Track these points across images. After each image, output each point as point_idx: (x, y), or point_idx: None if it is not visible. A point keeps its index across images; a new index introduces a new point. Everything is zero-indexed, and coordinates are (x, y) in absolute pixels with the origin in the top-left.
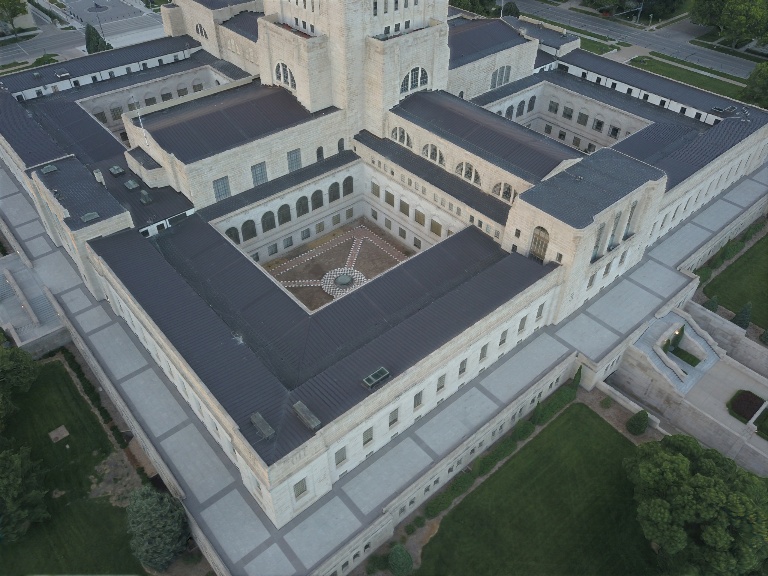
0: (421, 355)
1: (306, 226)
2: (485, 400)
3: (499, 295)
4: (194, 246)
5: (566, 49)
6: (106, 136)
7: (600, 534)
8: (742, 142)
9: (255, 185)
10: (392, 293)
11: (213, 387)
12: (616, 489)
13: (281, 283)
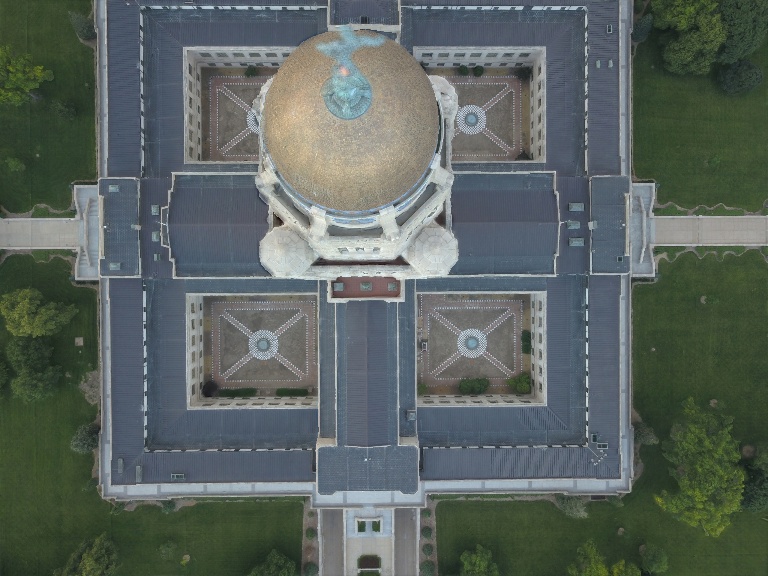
0: (206, 479)
1: None
2: None
3: (271, 474)
4: (169, 307)
5: None
6: (180, 130)
7: (249, 552)
8: (549, 480)
9: None
10: (236, 422)
11: (115, 430)
12: (274, 544)
13: (231, 318)
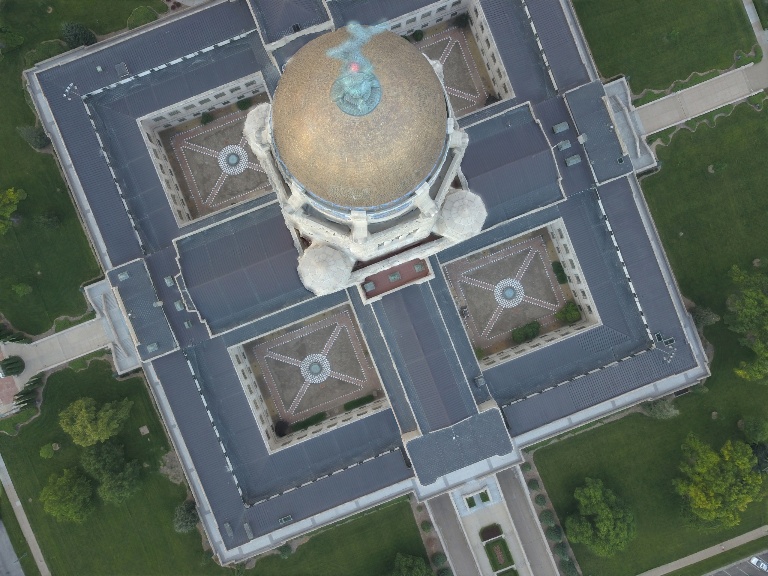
0: (312, 512)
1: None
2: (352, 502)
3: (370, 485)
4: (216, 367)
5: None
6: (163, 198)
7: (376, 565)
8: None
9: None
10: (319, 449)
11: (211, 498)
12: (396, 549)
13: (276, 355)
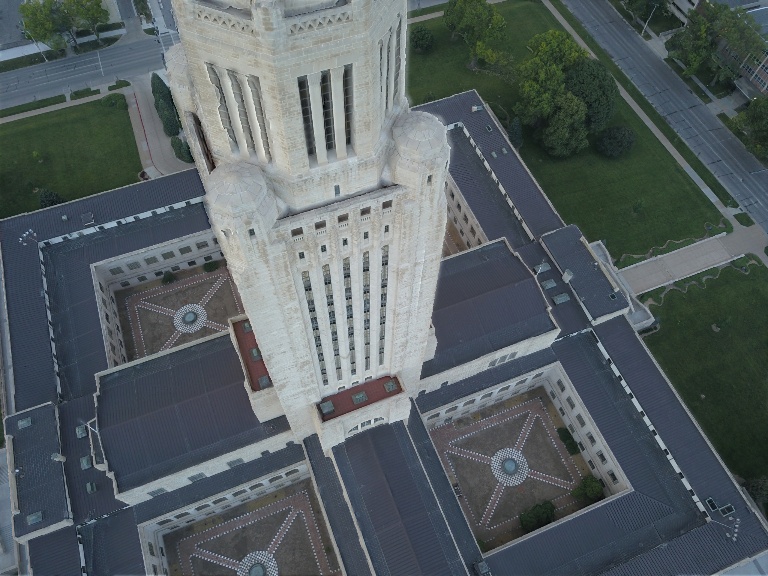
0: None
1: None
2: None
3: None
4: (118, 554)
5: (605, 319)
6: (99, 341)
7: None
8: None
9: (194, 480)
10: None
11: None
12: None
13: (206, 554)
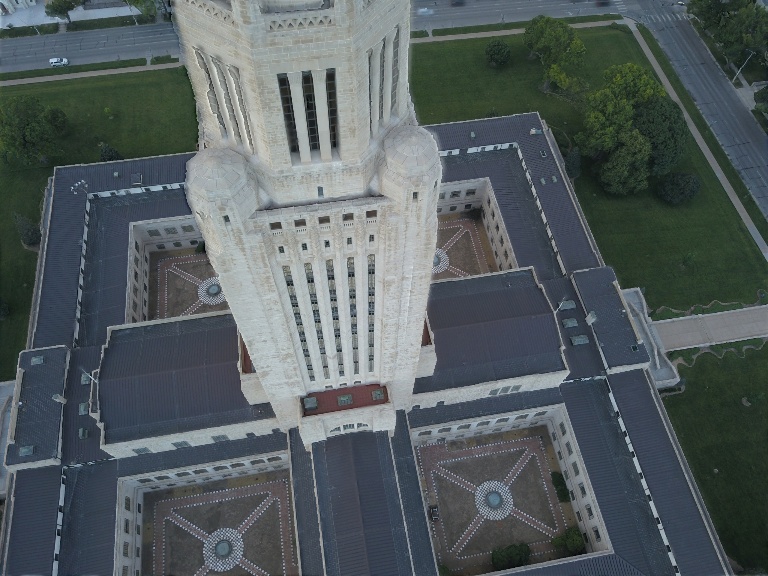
0: None
1: (226, 474)
2: None
3: None
4: (94, 501)
5: (622, 369)
6: (122, 296)
7: None
8: None
9: (179, 447)
10: None
11: None
12: None
13: (180, 519)
